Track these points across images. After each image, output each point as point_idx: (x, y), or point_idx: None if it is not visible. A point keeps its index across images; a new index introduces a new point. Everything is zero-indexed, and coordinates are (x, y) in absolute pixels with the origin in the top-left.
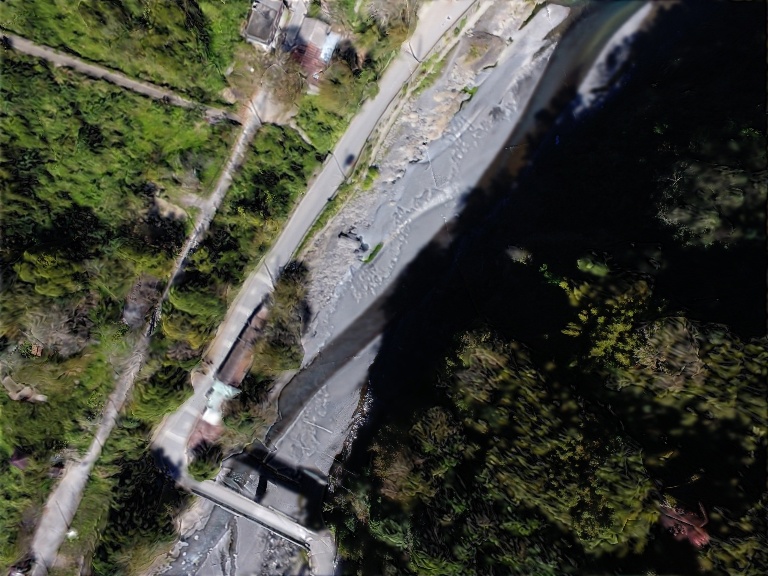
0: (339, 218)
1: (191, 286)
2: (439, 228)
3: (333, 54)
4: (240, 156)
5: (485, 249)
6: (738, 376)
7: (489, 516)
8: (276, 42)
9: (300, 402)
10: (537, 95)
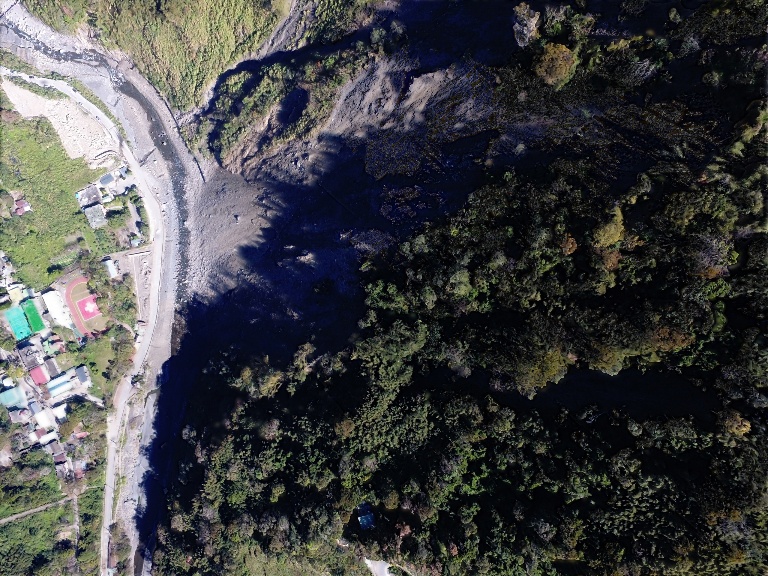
0: (121, 498)
1: (81, 554)
2: (155, 481)
3: (86, 466)
4: (76, 509)
5: (169, 482)
6: (190, 524)
7: (173, 574)
8: (68, 473)
9: (142, 557)
10: (161, 425)
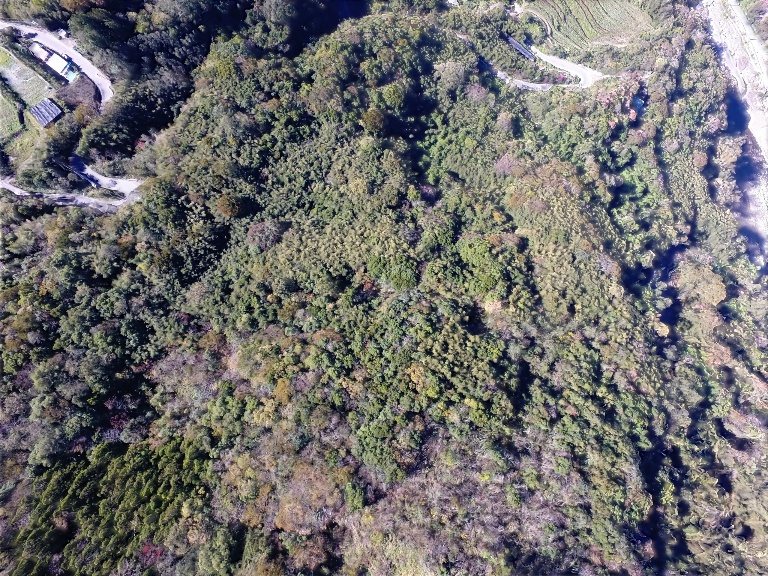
0: (719, 2)
1: None
2: None
3: (767, 10)
4: None
5: None
6: None
7: None
8: None
9: None
10: None
